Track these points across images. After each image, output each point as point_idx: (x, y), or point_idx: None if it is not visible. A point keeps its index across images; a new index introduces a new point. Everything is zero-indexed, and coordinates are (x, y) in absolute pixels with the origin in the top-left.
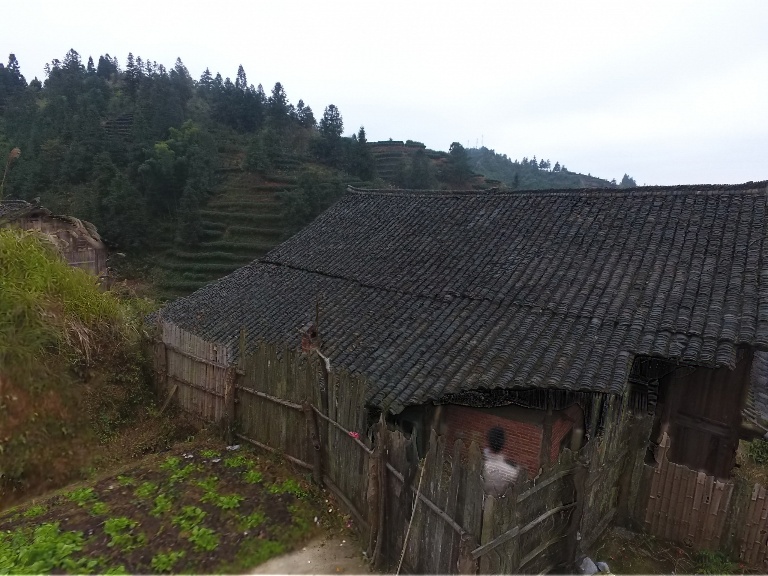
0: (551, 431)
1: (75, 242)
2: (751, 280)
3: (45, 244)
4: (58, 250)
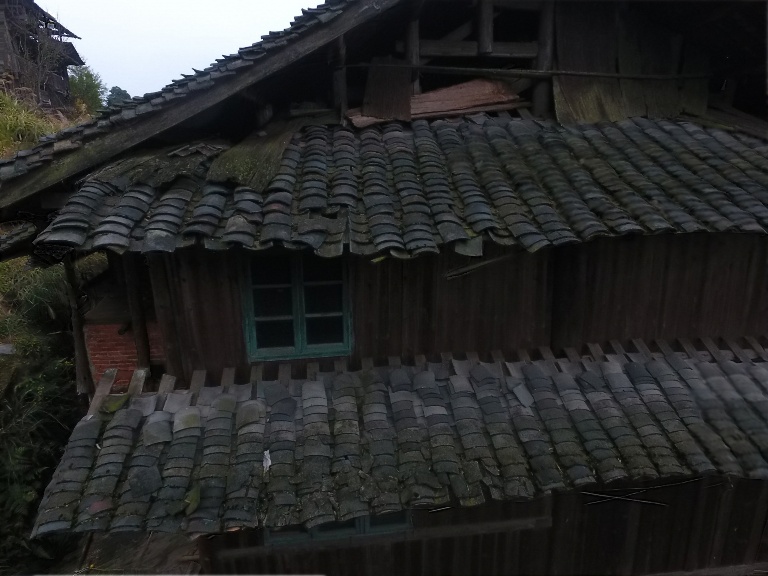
0: (78, 330)
1: None
2: None
3: (27, 126)
4: (37, 131)
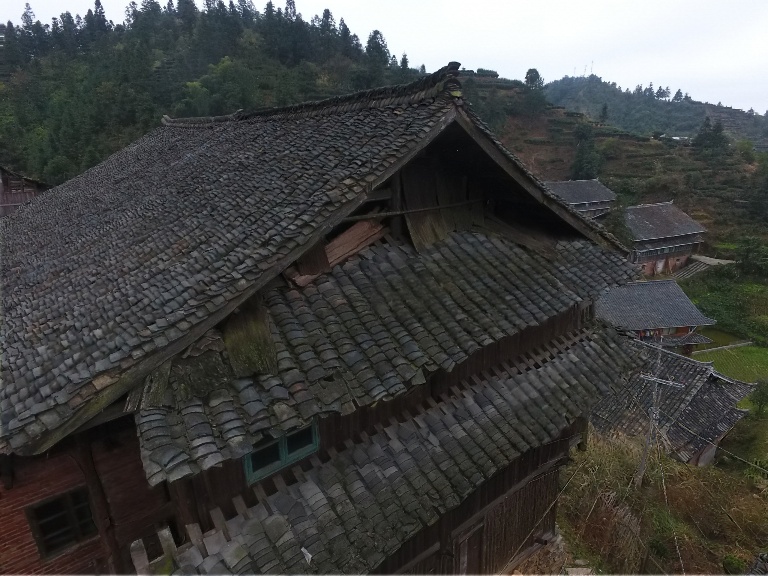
0: None
1: (6, 183)
2: (203, 279)
3: None
4: None
